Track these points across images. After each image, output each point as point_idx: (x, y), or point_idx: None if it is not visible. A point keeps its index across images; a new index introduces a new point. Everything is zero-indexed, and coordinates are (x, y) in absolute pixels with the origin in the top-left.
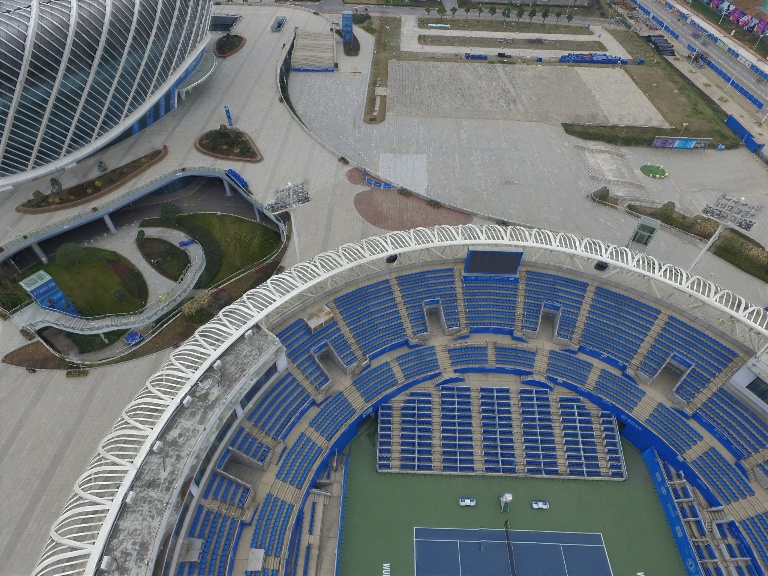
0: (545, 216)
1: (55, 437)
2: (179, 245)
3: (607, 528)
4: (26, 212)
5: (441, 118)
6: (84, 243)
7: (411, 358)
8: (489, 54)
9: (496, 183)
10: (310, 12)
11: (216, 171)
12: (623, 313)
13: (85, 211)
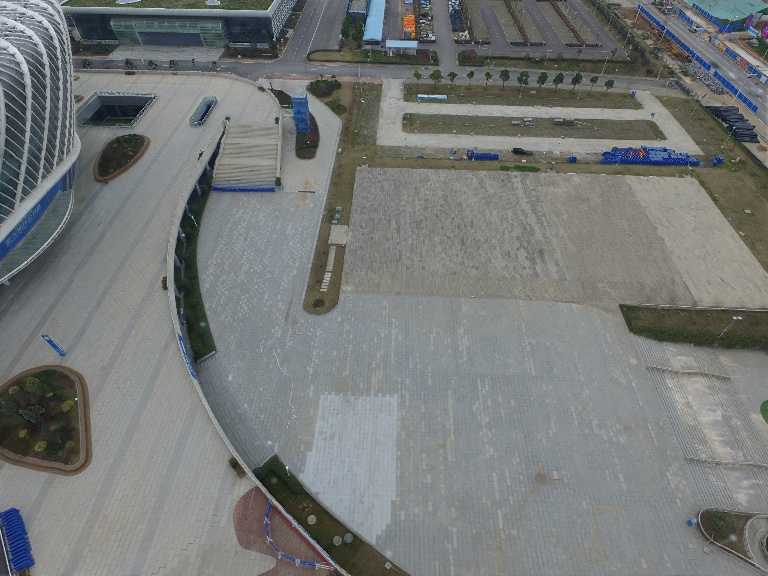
0: None
1: None
2: None
3: None
4: None
5: (427, 297)
6: None
7: None
8: (501, 149)
9: (519, 480)
10: (254, 86)
11: None
12: None
13: None
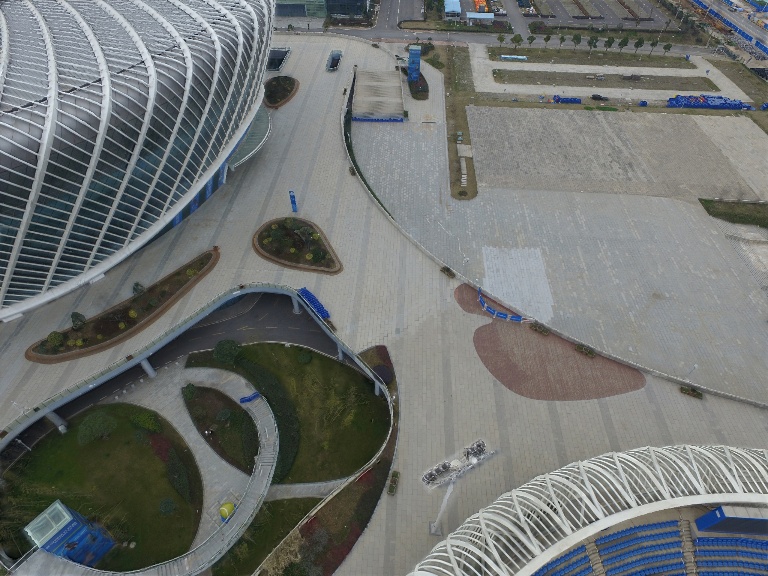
0: (722, 355)
1: None
2: (240, 401)
3: None
4: (39, 360)
5: (547, 191)
6: (114, 396)
7: None
8: (581, 96)
9: (641, 297)
10: (368, 44)
11: (284, 289)
12: None
13: (117, 362)
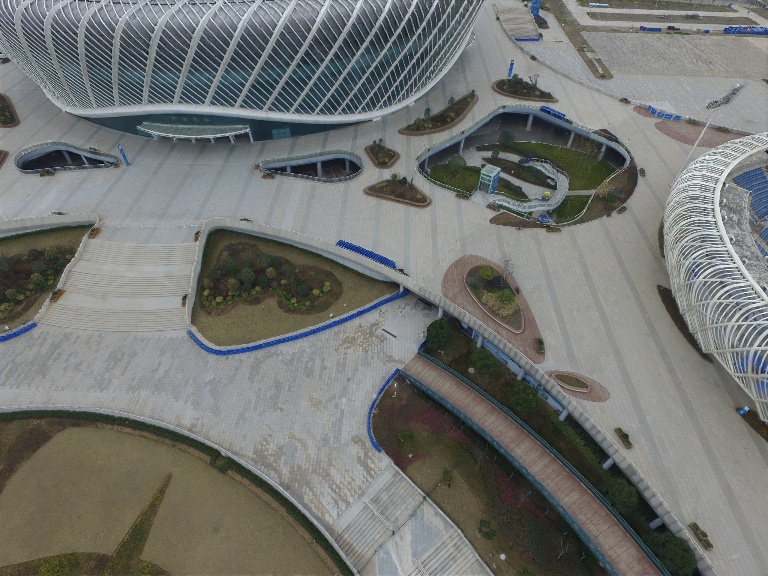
0: None
1: (574, 264)
2: None
3: None
4: (409, 134)
5: (659, 75)
6: (445, 161)
7: None
8: (659, 27)
9: (740, 122)
10: None
11: (530, 108)
12: None
13: (459, 133)
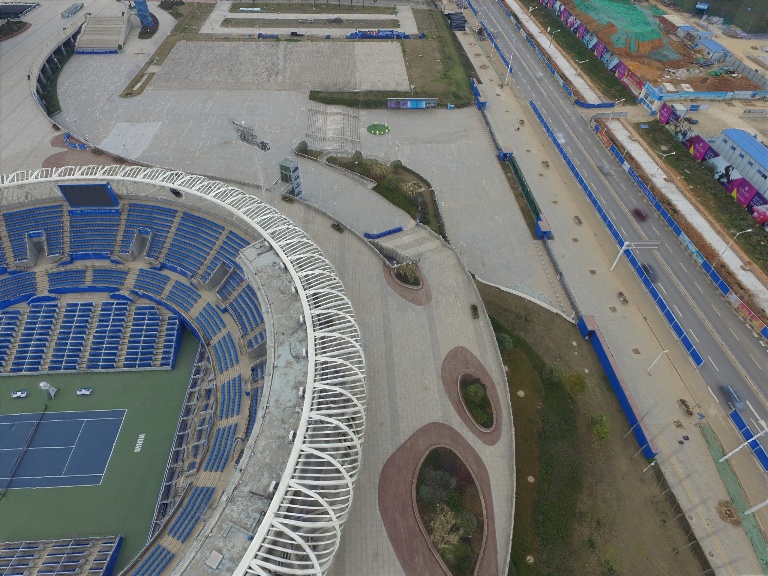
0: (242, 169)
1: None
2: None
3: (135, 405)
4: None
5: (197, 90)
6: None
7: (8, 283)
8: (284, 34)
9: (214, 143)
10: None
11: None
12: (200, 233)
13: None
